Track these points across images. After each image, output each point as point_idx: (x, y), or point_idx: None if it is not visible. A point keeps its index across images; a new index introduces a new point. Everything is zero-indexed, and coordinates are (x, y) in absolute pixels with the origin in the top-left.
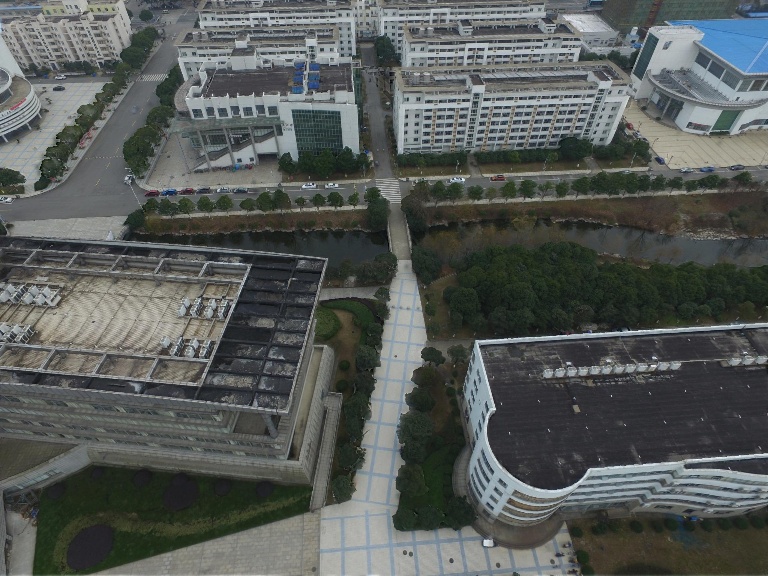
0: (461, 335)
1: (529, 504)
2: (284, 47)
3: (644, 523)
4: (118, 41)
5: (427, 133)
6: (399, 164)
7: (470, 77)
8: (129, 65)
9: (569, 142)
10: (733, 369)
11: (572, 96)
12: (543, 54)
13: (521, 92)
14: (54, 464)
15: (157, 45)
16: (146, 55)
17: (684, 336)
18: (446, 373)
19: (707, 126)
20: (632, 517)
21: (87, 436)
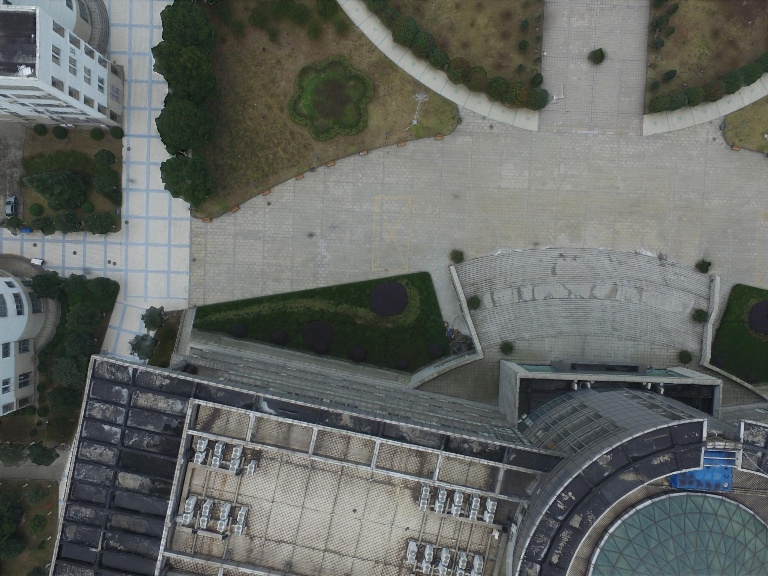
0: None
1: None
2: None
3: None
4: None
5: None
6: None
7: None
8: None
9: None
10: None
11: None
12: None
13: None
14: (434, 372)
15: None
16: None
17: None
18: None
19: None
20: None
21: None
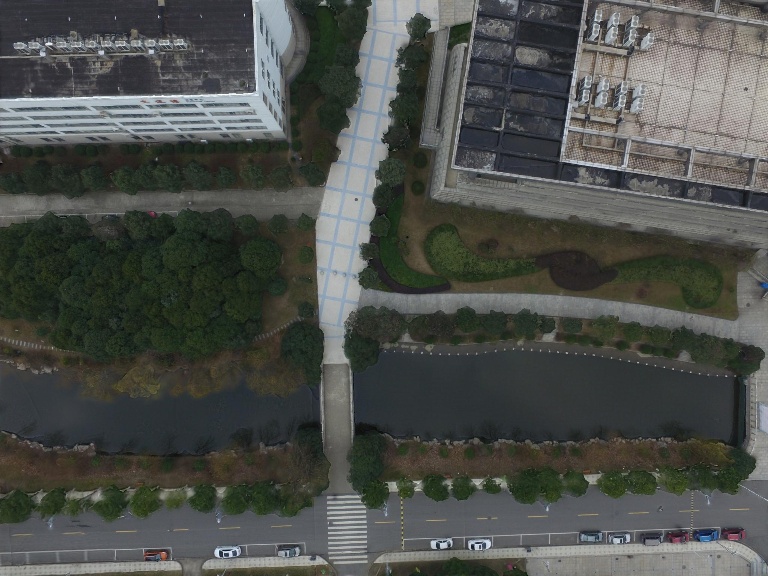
0: None
1: None
2: None
3: None
4: None
5: None
6: None
7: None
8: None
9: None
10: None
11: None
12: None
13: None
14: None
15: None
16: None
17: None
18: None
19: None
20: None
21: None
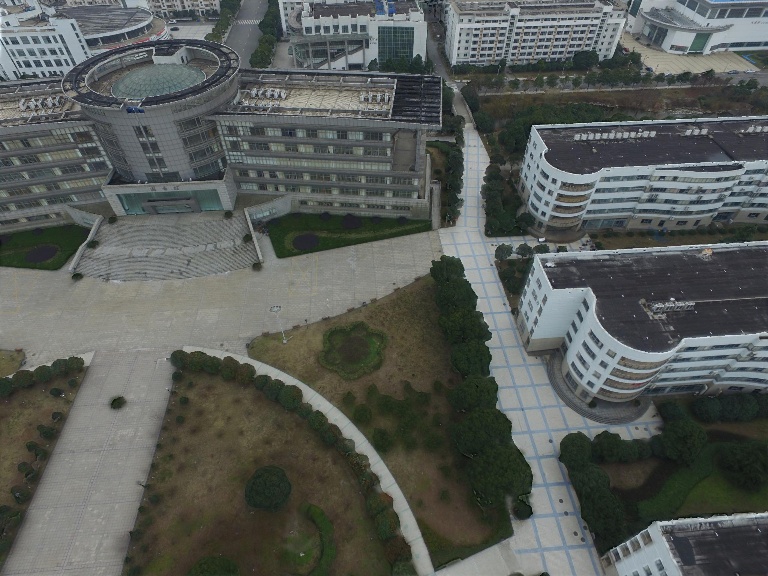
0: None
1: (569, 194)
2: None
3: (635, 233)
4: None
5: (474, 49)
6: (454, 71)
7: (508, 4)
8: (230, 10)
9: (581, 54)
10: (687, 137)
11: (583, 18)
12: None
13: (546, 15)
14: (275, 203)
15: (241, 1)
16: (240, 4)
17: (659, 126)
18: (505, 175)
19: (685, 47)
20: (627, 231)
21: (296, 185)
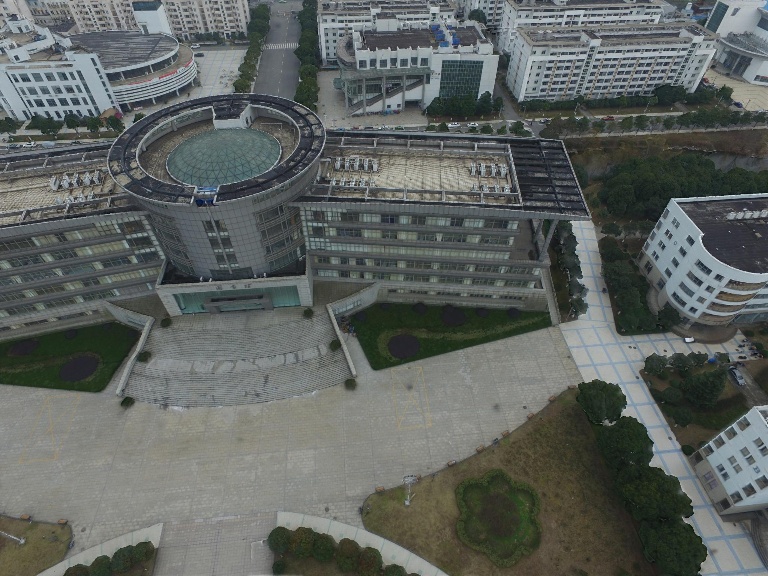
0: (620, 222)
1: (736, 293)
2: (411, 14)
3: None
4: (243, 15)
5: (545, 83)
6: None
7: (586, 34)
8: None
9: (665, 89)
10: None
11: (670, 49)
12: (628, 21)
13: (629, 46)
14: (362, 295)
15: None
16: (270, 27)
17: None
18: (618, 246)
19: None
20: None
21: None
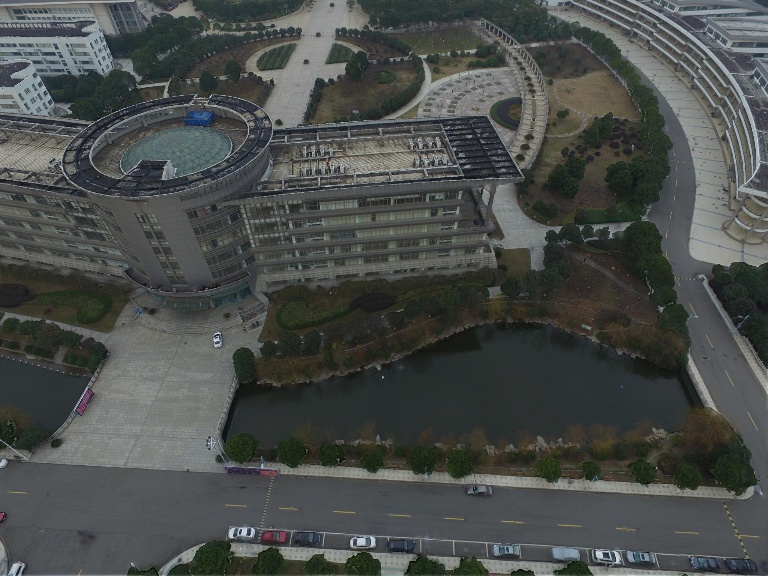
0: None
1: None
2: None
3: None
4: None
5: None
6: None
7: None
8: None
9: None
10: None
11: None
12: None
13: None
14: None
15: None
16: None
17: None
18: None
19: None
20: None
21: None
